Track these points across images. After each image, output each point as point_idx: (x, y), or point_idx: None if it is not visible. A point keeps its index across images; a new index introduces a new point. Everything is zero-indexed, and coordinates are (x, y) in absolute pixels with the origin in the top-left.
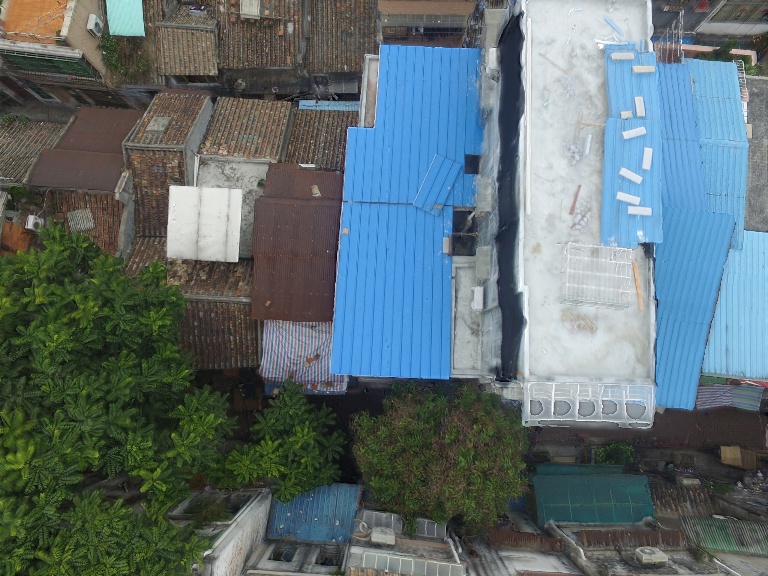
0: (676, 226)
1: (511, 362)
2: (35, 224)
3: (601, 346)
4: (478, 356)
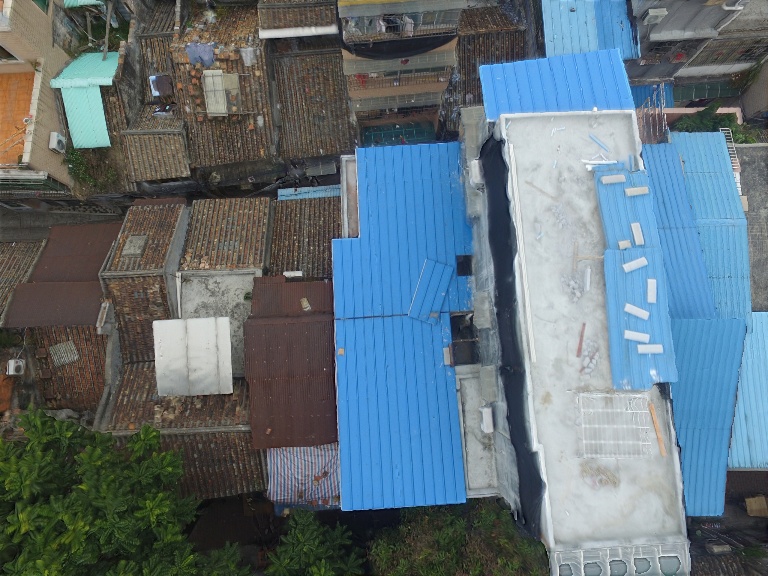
0: (686, 336)
1: (533, 525)
2: (16, 368)
3: (626, 501)
4: (493, 472)
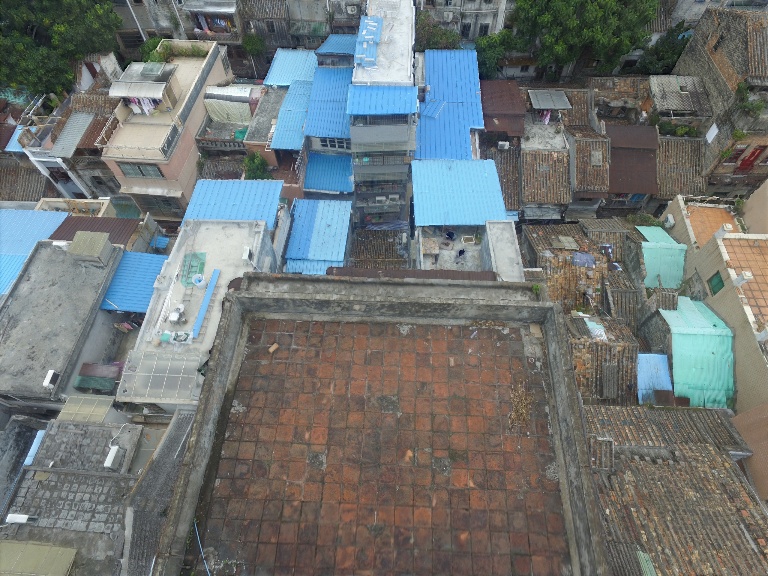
0: None
1: None
2: None
3: None
4: None
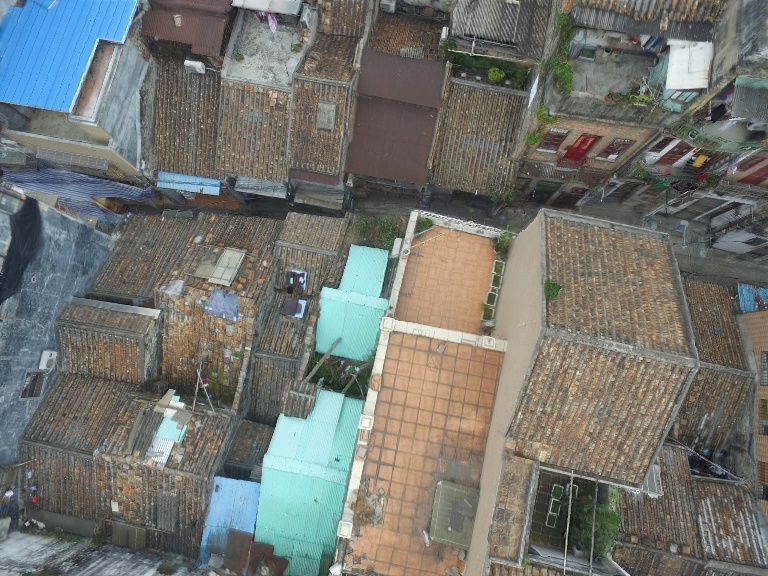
0: None
1: None
2: None
3: None
4: None
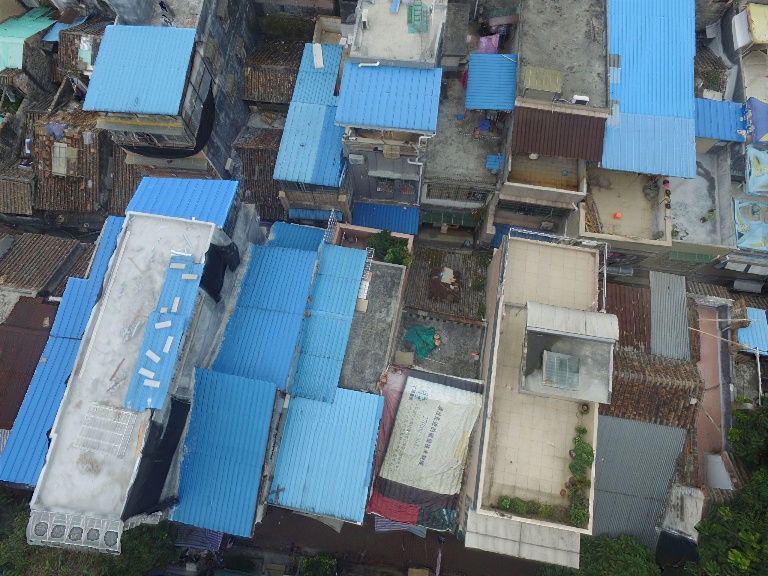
0: (232, 388)
1: None
2: None
3: (98, 485)
4: None
